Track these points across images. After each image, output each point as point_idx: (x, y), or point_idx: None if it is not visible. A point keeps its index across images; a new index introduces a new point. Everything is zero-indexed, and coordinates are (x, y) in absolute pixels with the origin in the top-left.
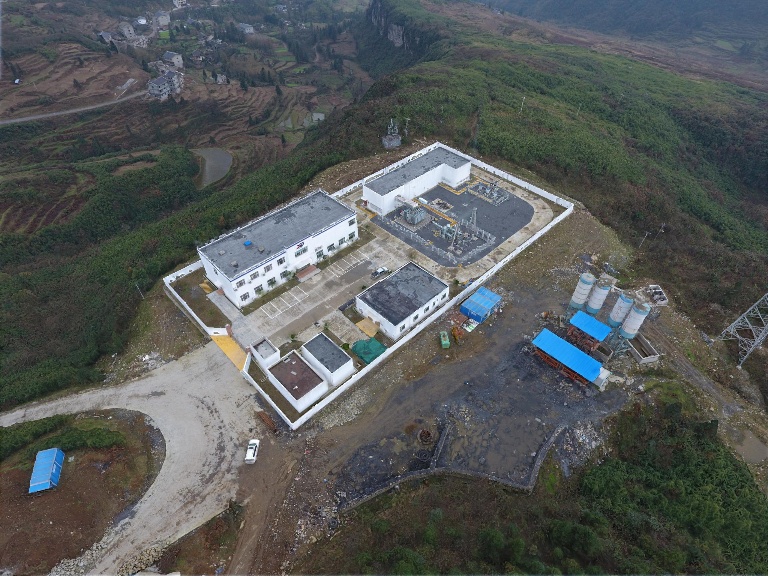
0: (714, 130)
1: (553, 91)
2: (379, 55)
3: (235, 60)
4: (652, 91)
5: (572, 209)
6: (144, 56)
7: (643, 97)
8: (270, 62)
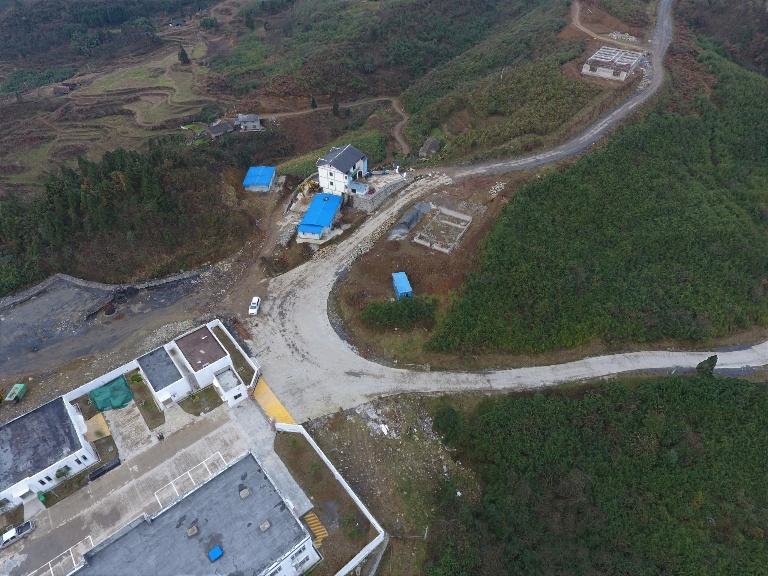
0: None
1: None
2: None
3: None
4: None
5: None
6: None
7: None
8: None
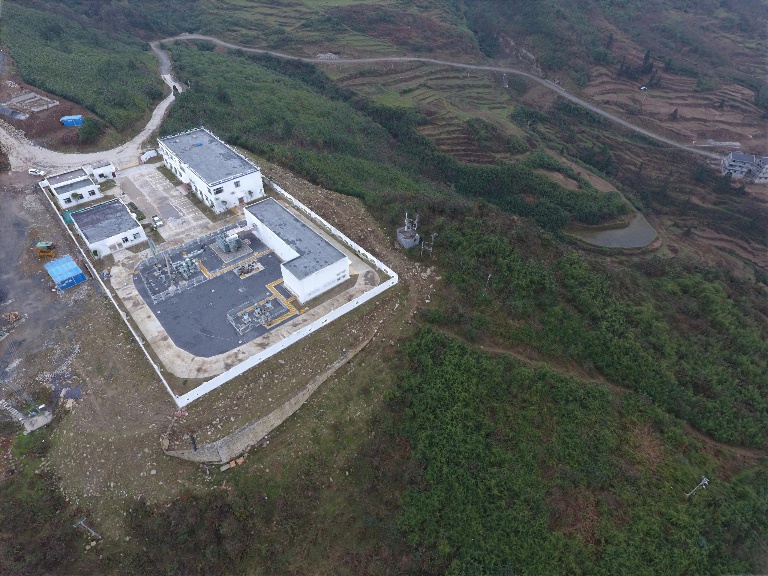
0: None
1: None
2: None
3: None
4: None
5: None
6: None
7: None
8: None
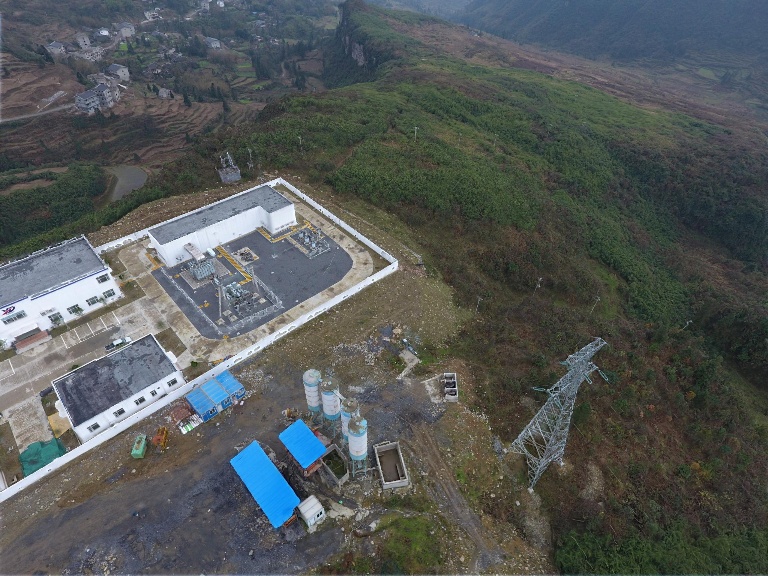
0: (652, 165)
1: (476, 119)
2: (342, 73)
3: (189, 74)
4: (593, 121)
5: (398, 266)
6: (84, 68)
7: (579, 128)
8: (228, 77)
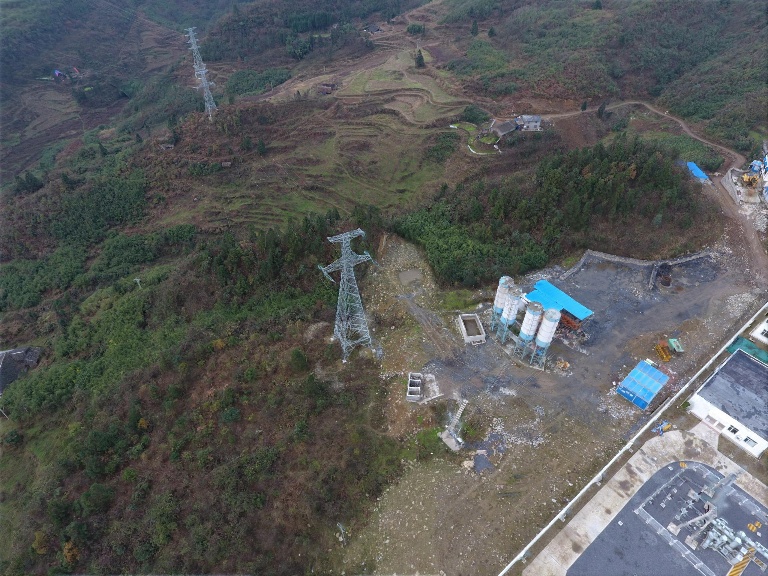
0: None
1: None
2: None
3: None
4: None
5: None
6: None
7: None
8: None
